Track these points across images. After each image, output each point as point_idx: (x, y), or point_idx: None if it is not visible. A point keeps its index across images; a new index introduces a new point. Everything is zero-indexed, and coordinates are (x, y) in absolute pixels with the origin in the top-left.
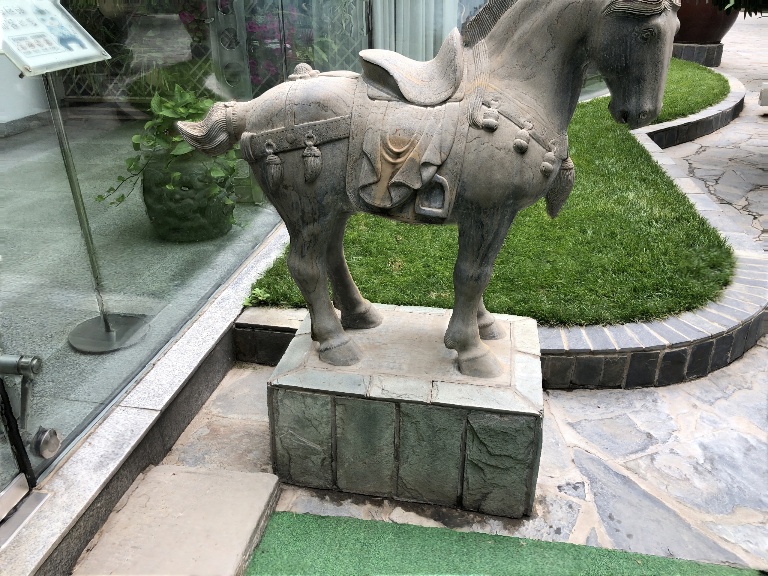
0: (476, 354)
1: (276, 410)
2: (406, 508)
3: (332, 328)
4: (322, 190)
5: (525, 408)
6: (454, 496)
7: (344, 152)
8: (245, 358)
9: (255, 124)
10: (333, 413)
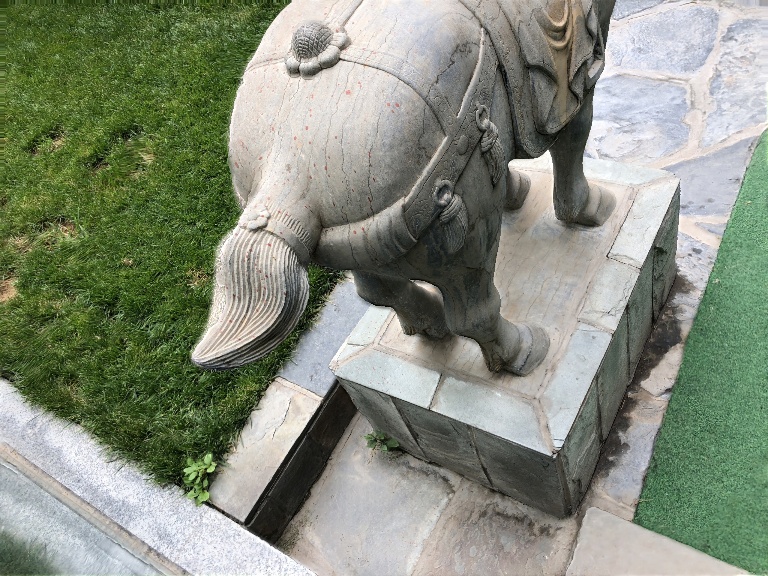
0: (598, 195)
1: (566, 465)
2: (644, 376)
3: (517, 333)
4: (503, 178)
5: (672, 186)
6: (650, 322)
7: (502, 95)
8: (278, 533)
9: (394, 184)
10: (596, 391)
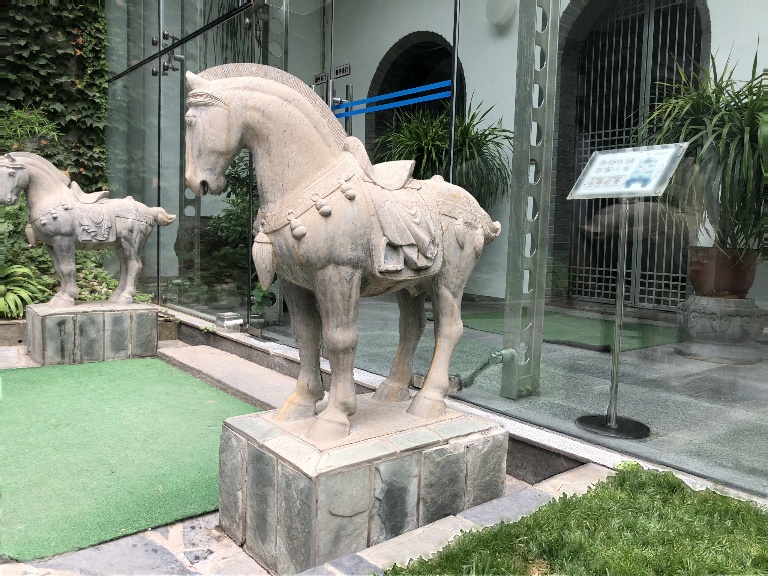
0: None
1: None
2: None
3: None
4: None
5: None
6: None
7: None
8: None
9: None
10: None
